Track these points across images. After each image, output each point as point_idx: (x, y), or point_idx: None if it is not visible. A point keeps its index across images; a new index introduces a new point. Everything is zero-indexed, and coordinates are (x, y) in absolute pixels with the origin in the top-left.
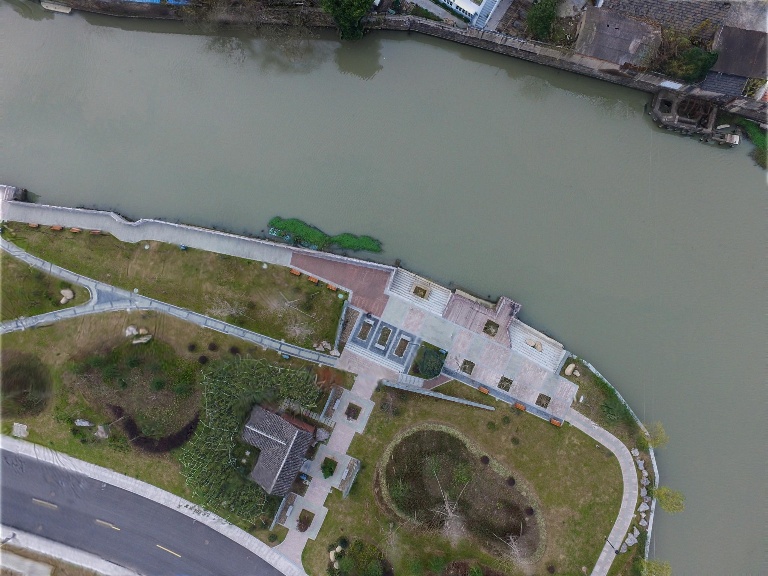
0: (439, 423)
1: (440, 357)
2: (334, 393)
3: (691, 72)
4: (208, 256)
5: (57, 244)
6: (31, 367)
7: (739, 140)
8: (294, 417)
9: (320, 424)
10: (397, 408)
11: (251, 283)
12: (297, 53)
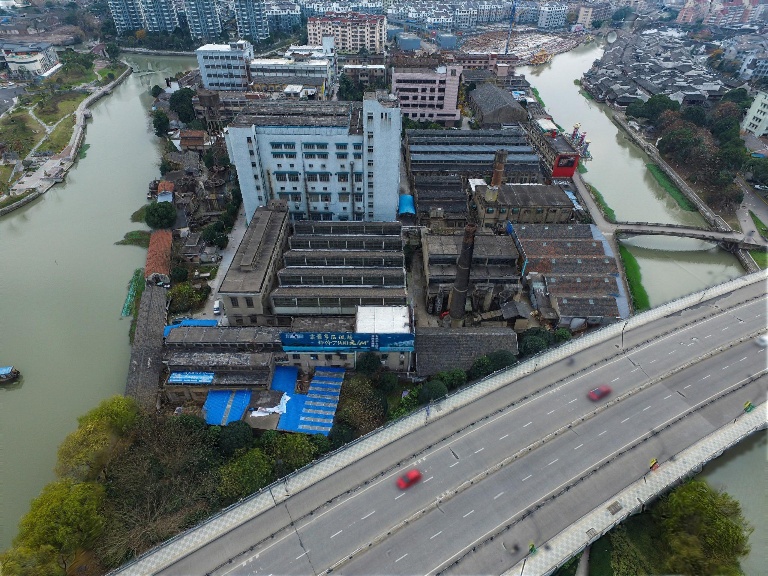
0: (1, 173)
1: (33, 170)
2: (15, 158)
3: (159, 166)
4: (70, 135)
5: (69, 119)
6: (22, 122)
7: (149, 197)
8: (2, 145)
9: (1, 159)
10: (8, 166)
11: (59, 140)
12: (149, 131)
